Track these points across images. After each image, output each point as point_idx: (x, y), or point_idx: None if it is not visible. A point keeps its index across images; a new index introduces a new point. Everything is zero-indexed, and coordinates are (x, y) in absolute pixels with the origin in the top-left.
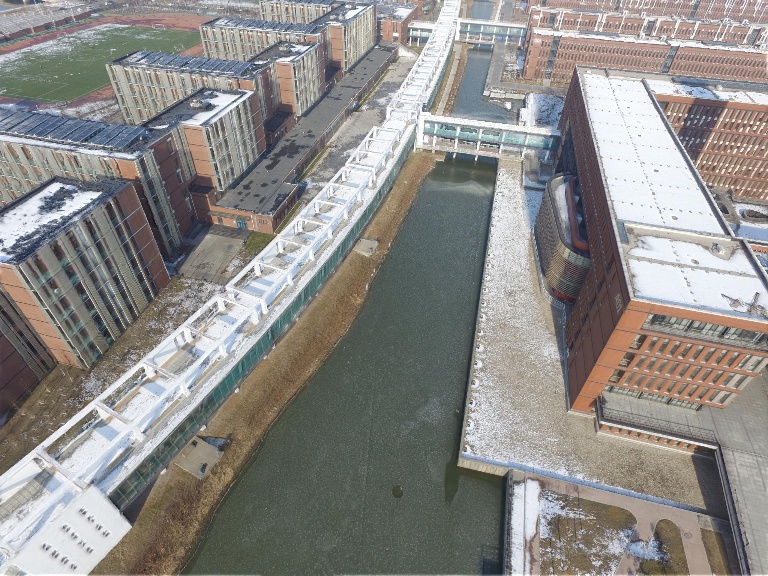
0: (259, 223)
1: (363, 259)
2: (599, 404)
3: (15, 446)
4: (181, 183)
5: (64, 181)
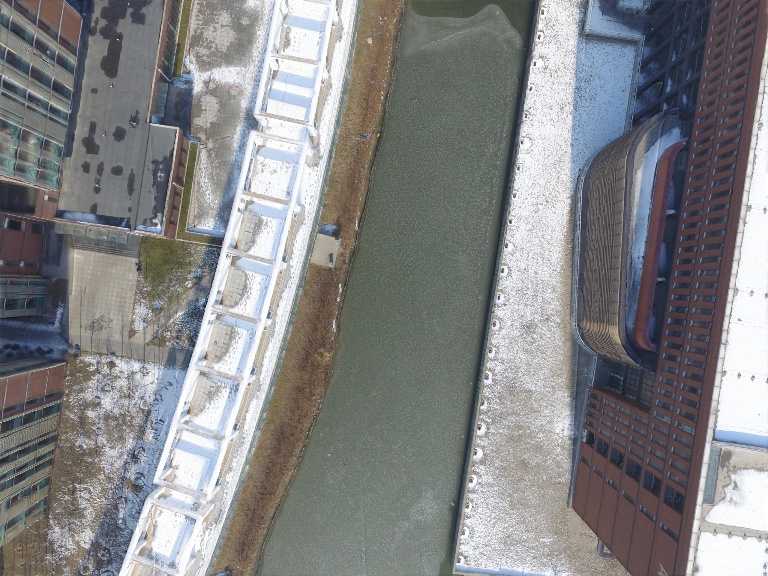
0: None
1: (321, 274)
2: None
3: None
4: None
5: None
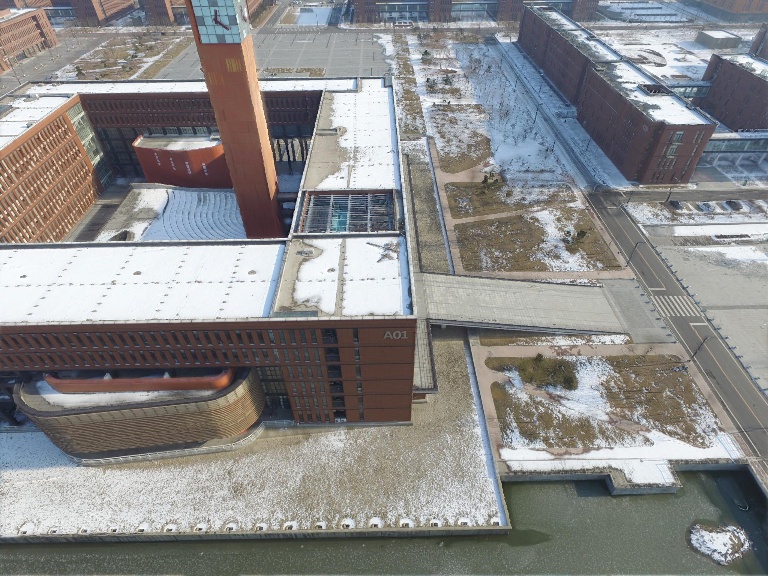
0: None
1: None
2: (420, 391)
3: None
4: None
5: None
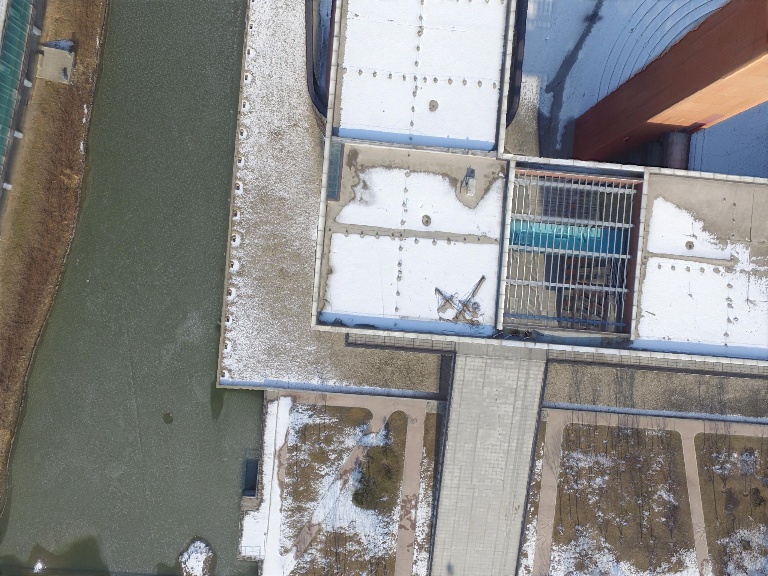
0: None
1: (60, 92)
2: None
3: None
4: None
5: None
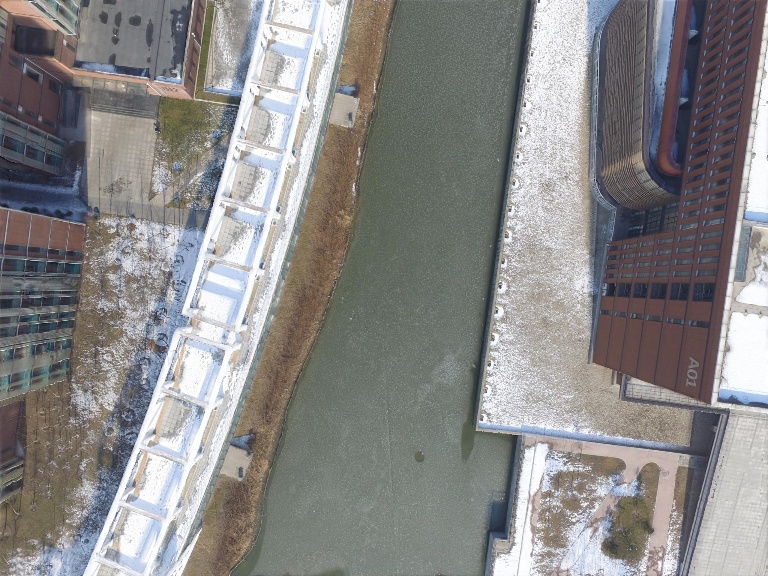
0: (164, 90)
1: (340, 136)
2: (625, 381)
3: (52, 476)
4: None
5: None
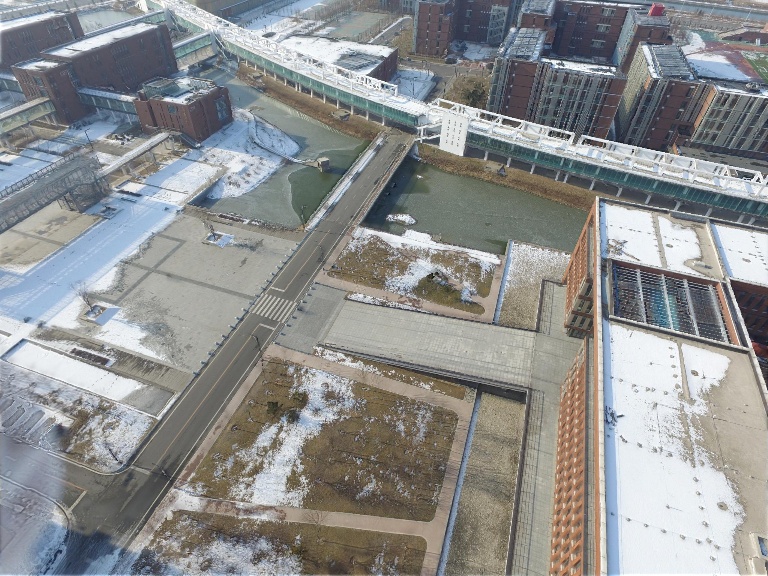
0: None
1: None
2: None
3: None
4: (677, 119)
5: (618, 69)
